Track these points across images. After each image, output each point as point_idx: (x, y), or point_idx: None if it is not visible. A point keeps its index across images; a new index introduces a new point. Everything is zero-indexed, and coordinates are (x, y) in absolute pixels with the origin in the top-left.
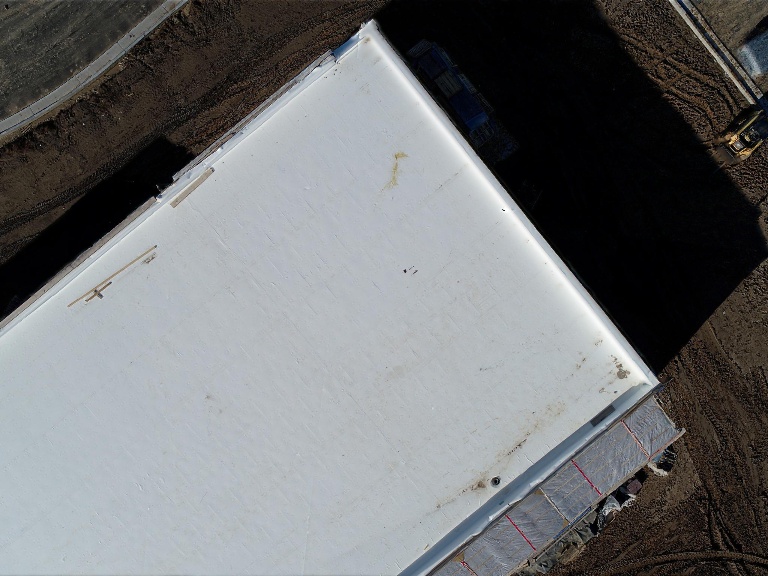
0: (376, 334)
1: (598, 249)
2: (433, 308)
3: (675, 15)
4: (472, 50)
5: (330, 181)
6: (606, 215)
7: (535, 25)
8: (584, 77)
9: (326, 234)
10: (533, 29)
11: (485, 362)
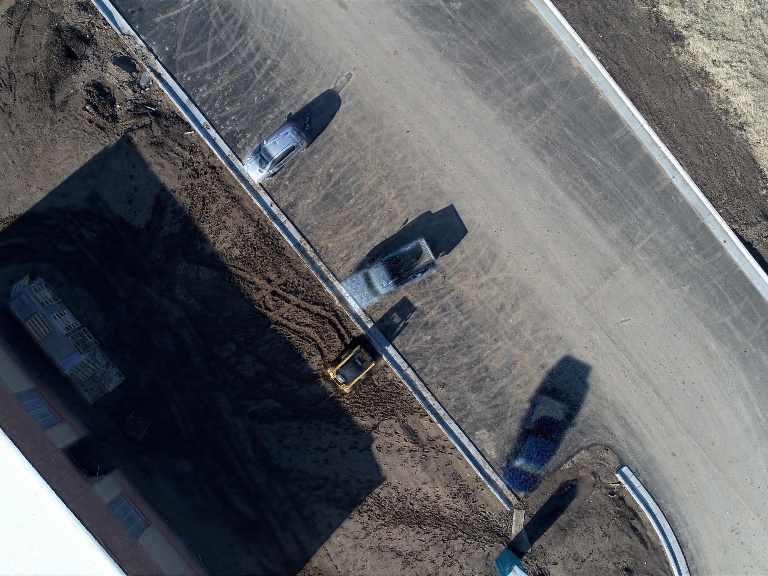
0: None
1: (208, 478)
2: None
3: (285, 245)
4: (78, 284)
5: None
6: (215, 445)
7: (141, 258)
8: (190, 310)
9: None
10: (139, 263)
11: None
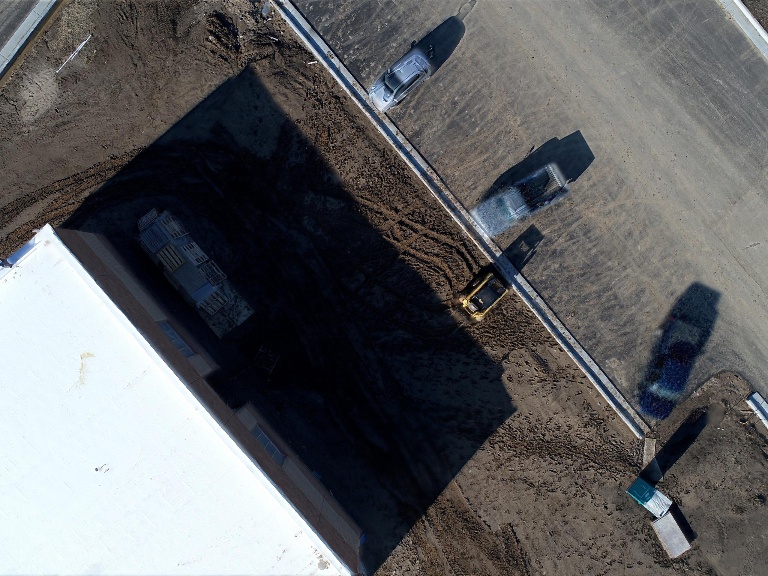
0: (69, 533)
1: (339, 412)
2: (127, 505)
3: (411, 175)
4: (204, 217)
5: (15, 383)
6: (345, 378)
7: (267, 190)
8: (318, 241)
9: (13, 436)
10: (265, 194)
11: (182, 557)
